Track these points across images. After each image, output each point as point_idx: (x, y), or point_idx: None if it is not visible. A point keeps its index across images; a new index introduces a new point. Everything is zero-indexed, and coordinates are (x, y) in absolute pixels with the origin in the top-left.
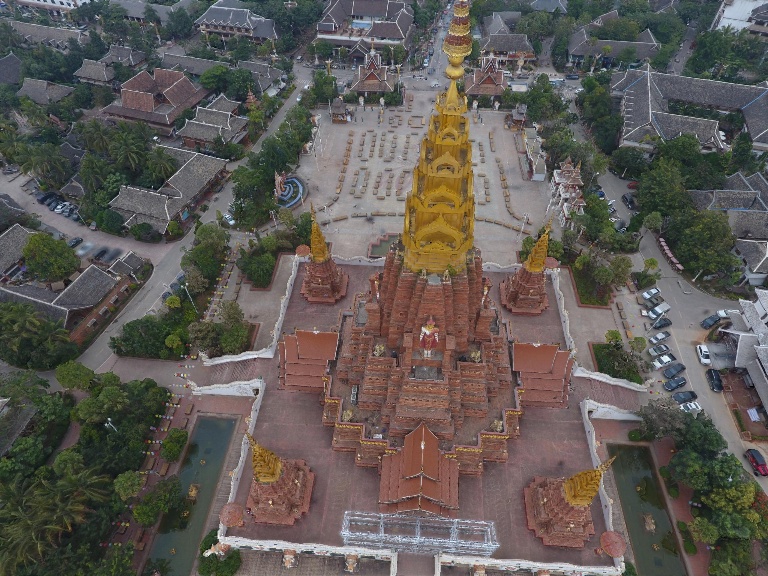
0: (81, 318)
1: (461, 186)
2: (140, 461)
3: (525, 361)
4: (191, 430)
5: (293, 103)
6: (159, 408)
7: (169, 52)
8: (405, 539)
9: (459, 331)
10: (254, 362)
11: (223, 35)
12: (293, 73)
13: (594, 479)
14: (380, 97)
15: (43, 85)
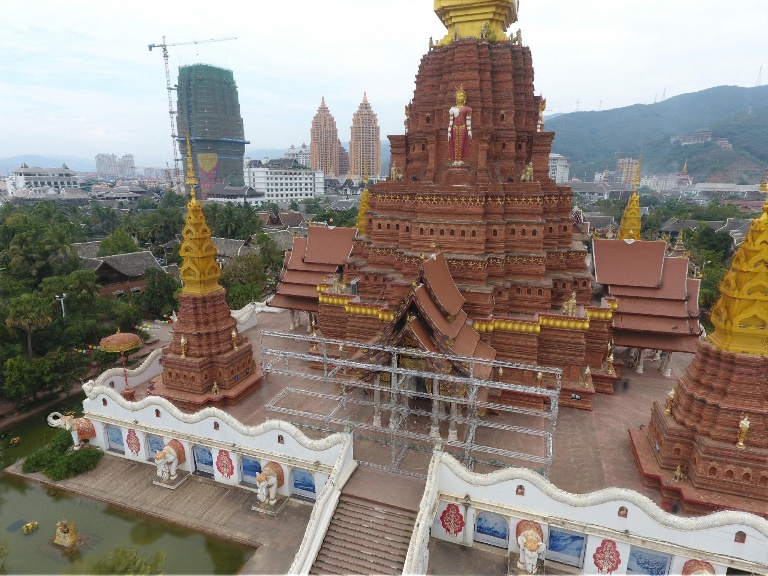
0: (111, 283)
1: None
2: None
3: (614, 269)
4: None
5: None
6: None
7: None
8: None
9: (503, 144)
10: None
11: None
12: None
13: (759, 235)
14: None
15: None
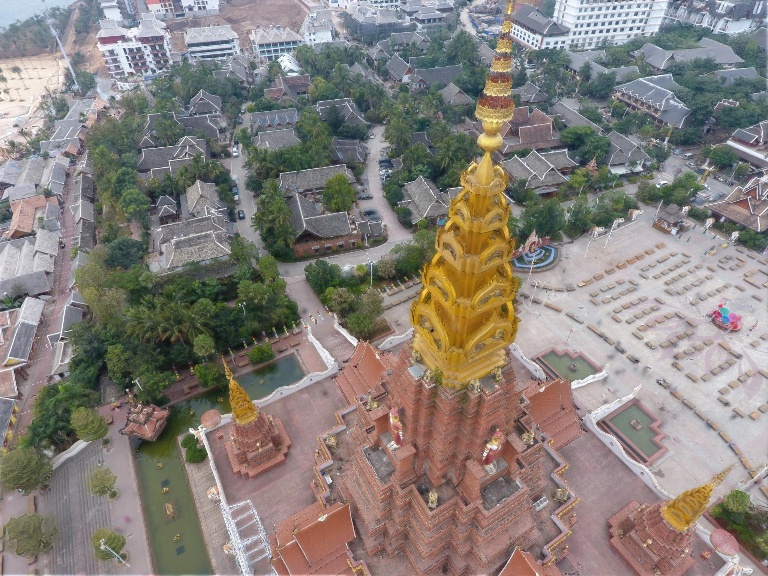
0: (312, 240)
1: (475, 287)
2: (241, 346)
3: None
4: (280, 357)
5: (634, 190)
6: (281, 326)
7: (564, 102)
8: (243, 569)
9: None
10: (353, 350)
11: (631, 107)
12: (664, 165)
13: None
14: (737, 230)
15: (456, 91)
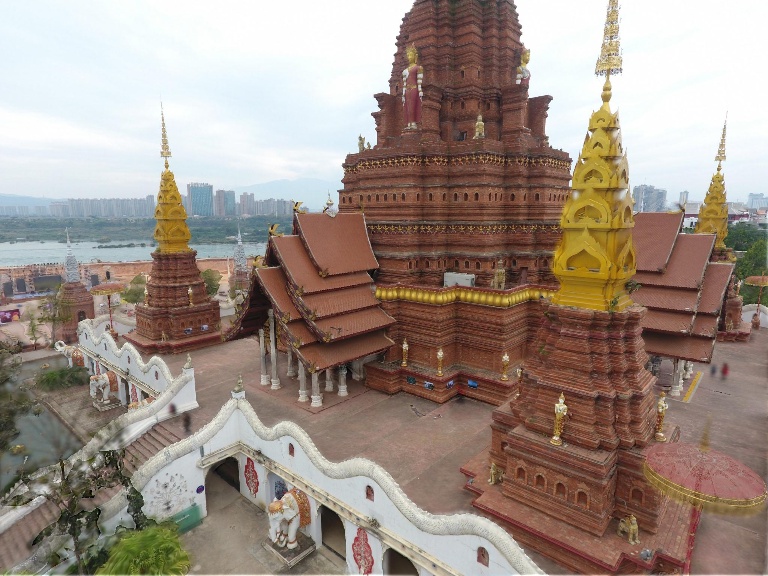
0: None
1: None
2: None
3: None
4: None
5: None
6: None
7: None
8: None
9: None
10: None
11: None
12: None
13: None
14: None
15: None
